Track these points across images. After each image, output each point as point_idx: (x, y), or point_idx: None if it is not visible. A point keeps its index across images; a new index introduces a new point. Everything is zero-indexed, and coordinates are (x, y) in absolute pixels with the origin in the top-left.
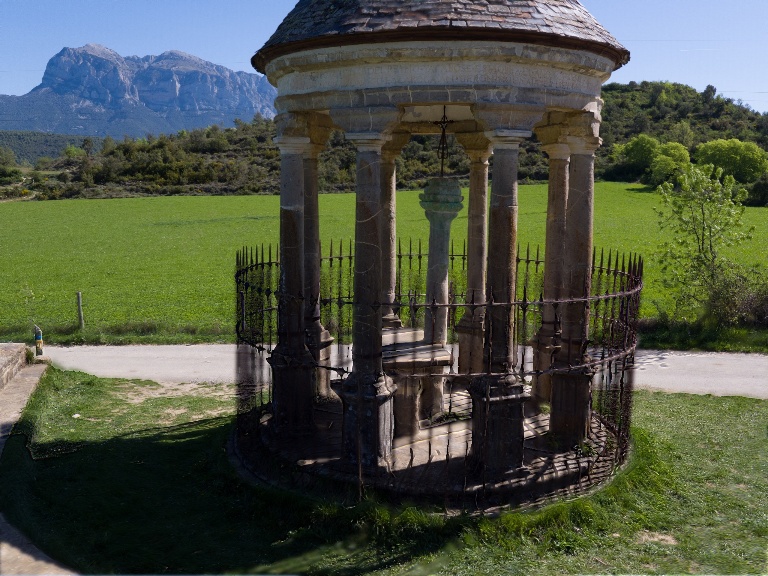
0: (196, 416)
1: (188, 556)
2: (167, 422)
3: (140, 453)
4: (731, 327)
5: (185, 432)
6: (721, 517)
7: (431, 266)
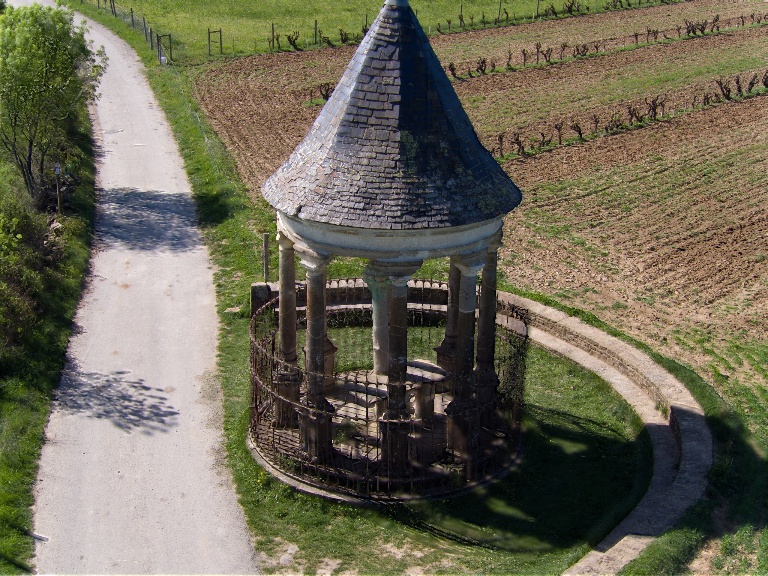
0: (418, 555)
1: (590, 455)
2: (446, 562)
3: (521, 525)
4: (35, 330)
5: (462, 536)
6: (414, 357)
7: None
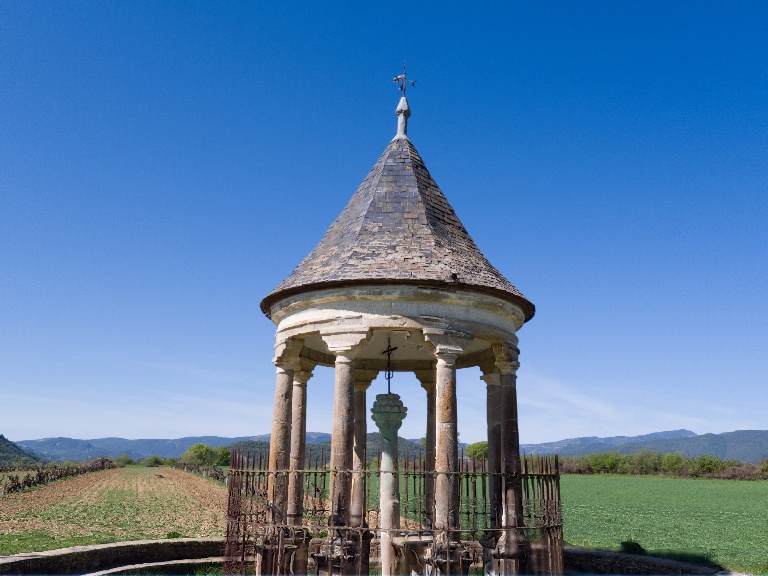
0: None
1: None
2: None
3: None
4: None
5: None
6: None
7: (397, 468)
